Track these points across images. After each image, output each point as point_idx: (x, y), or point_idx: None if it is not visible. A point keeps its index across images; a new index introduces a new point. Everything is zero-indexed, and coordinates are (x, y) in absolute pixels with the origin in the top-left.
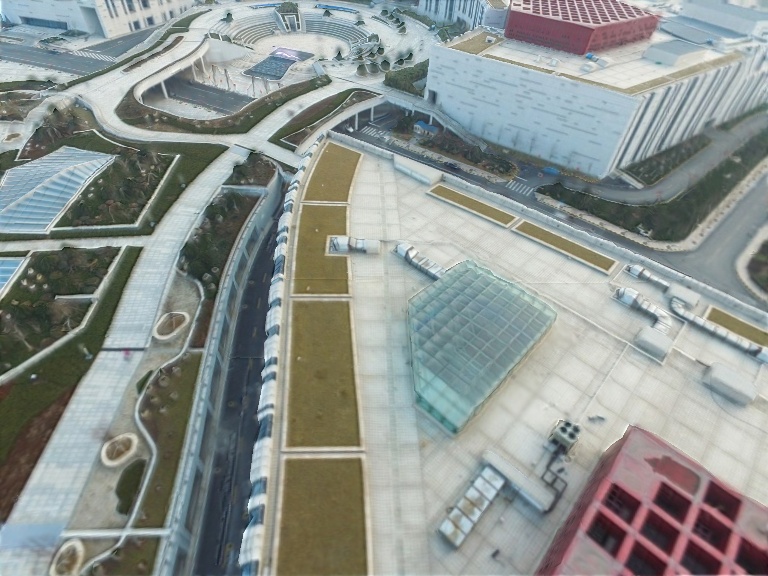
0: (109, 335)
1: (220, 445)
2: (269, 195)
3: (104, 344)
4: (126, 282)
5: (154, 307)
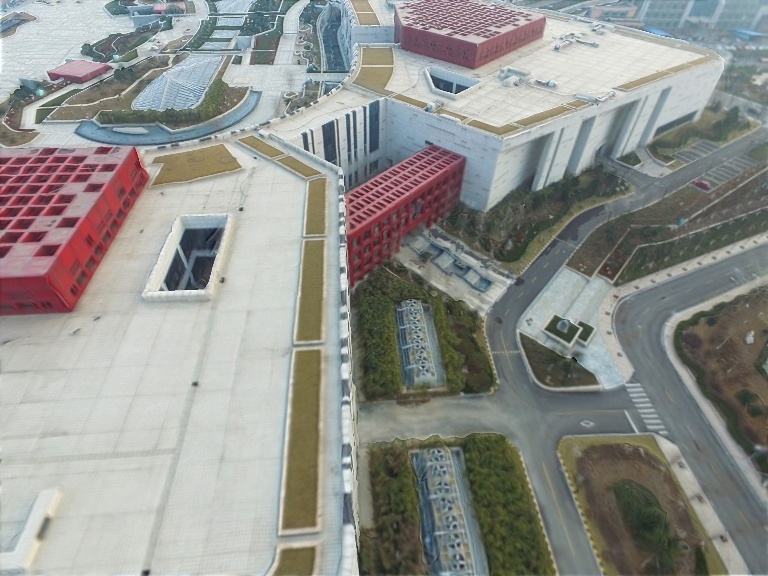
0: (284, 31)
1: (328, 56)
2: (326, 10)
3: (284, 32)
4: (283, 23)
5: (296, 27)
